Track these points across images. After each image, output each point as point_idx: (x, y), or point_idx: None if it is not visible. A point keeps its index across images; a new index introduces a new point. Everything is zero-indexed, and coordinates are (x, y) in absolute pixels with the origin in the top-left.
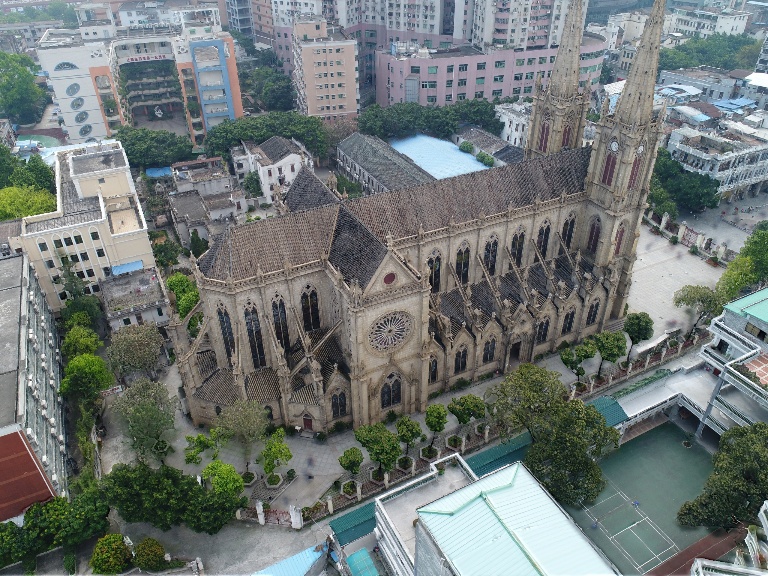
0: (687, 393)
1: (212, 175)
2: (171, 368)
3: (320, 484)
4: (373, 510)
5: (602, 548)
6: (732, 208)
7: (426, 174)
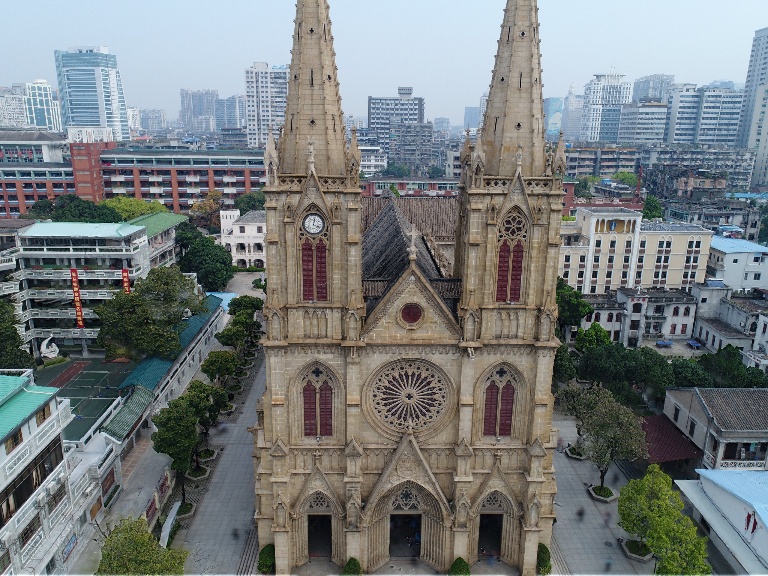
0: None
1: (757, 310)
2: None
3: None
4: (210, 303)
5: (87, 391)
6: None
7: None
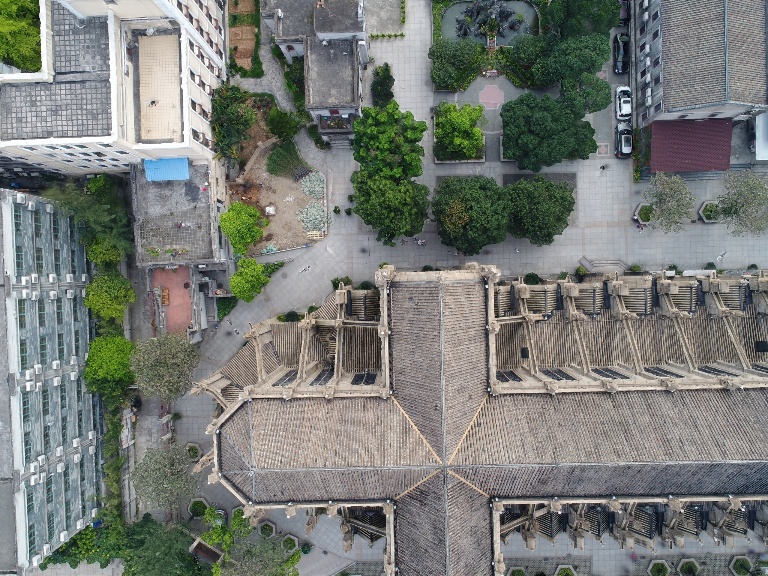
0: None
1: None
2: (219, 327)
3: (331, 564)
4: None
5: None
6: None
7: (767, 26)
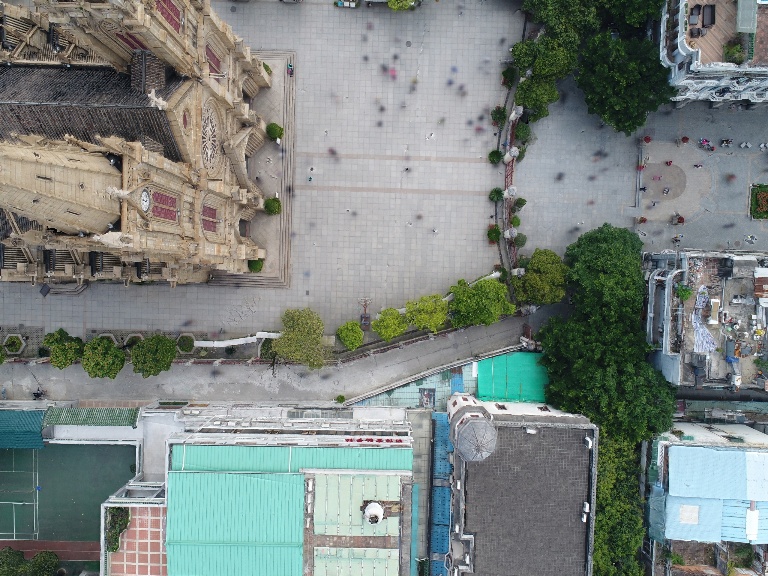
0: (156, 441)
1: None
2: None
3: None
4: None
5: None
6: (701, 122)
7: None
